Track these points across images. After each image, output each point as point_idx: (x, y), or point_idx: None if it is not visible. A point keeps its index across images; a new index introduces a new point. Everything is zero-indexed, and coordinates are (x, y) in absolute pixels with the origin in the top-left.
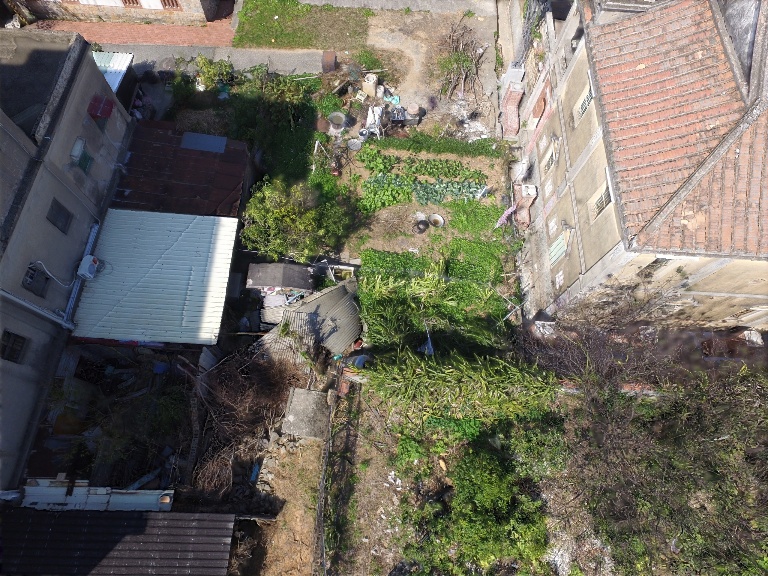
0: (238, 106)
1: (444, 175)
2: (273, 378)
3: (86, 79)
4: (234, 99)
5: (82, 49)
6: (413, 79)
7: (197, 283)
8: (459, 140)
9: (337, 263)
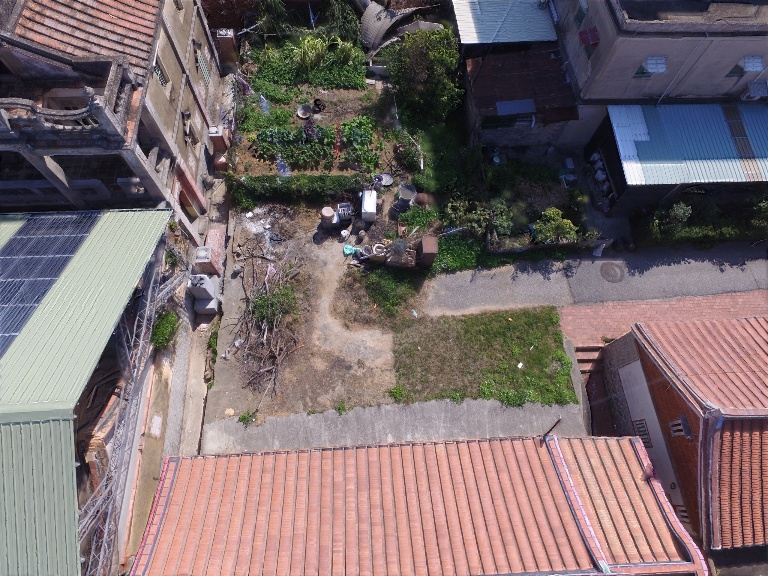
0: (515, 220)
1: (296, 146)
2: (412, 2)
3: (607, 28)
4: (523, 227)
5: (618, 22)
6: (329, 284)
7: (474, 7)
8: (279, 187)
9: (384, 80)
